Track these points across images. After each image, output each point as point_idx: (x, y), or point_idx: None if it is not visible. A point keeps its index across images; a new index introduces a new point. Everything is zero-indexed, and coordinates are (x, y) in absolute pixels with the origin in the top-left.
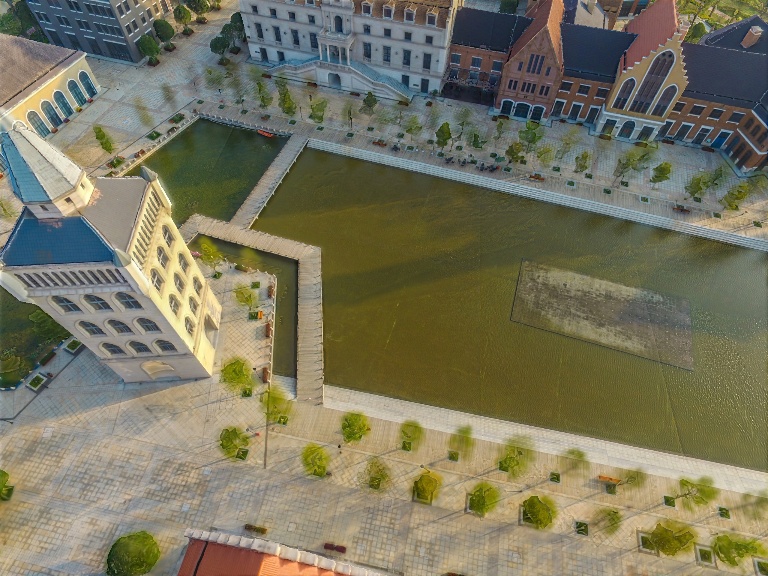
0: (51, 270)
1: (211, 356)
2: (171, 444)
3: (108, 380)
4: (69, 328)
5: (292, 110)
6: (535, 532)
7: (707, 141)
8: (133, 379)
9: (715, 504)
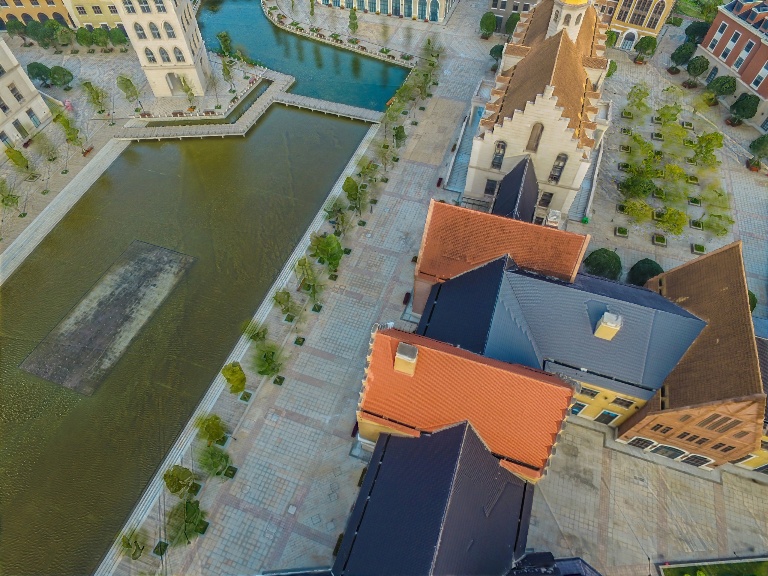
0: None
1: (165, 92)
2: None
3: None
4: None
5: (401, 100)
6: None
7: None
8: None
9: None
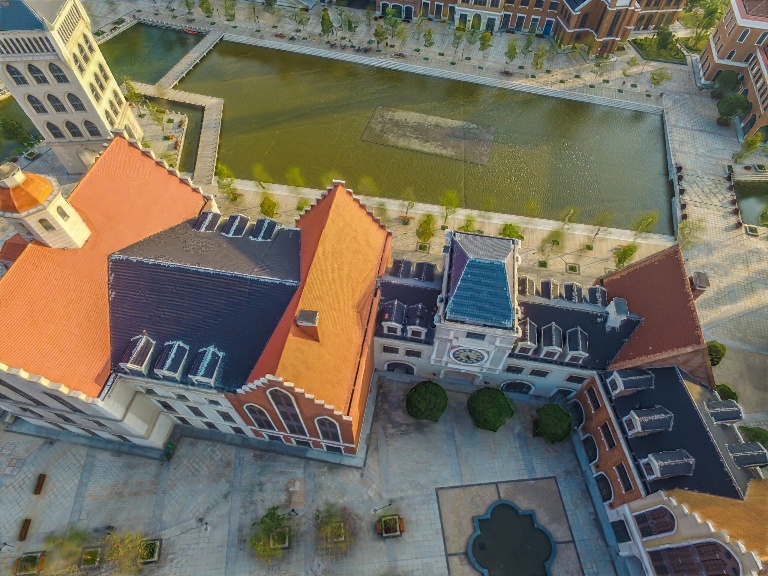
0: (3, 36)
1: None
2: None
3: (56, 173)
4: (21, 103)
5: (210, 11)
6: None
7: (539, 30)
8: (74, 170)
9: (475, 228)
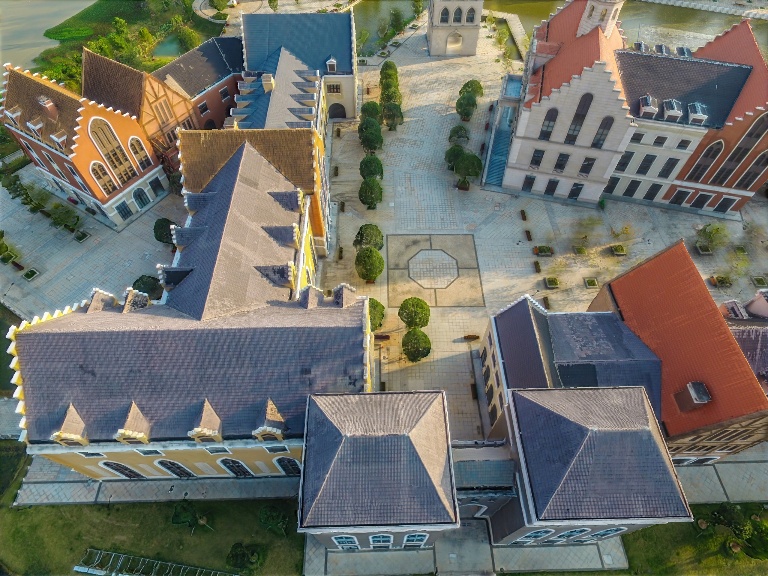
0: None
1: None
2: (465, 75)
3: (420, 55)
4: None
5: None
6: None
7: None
8: (436, 53)
9: None
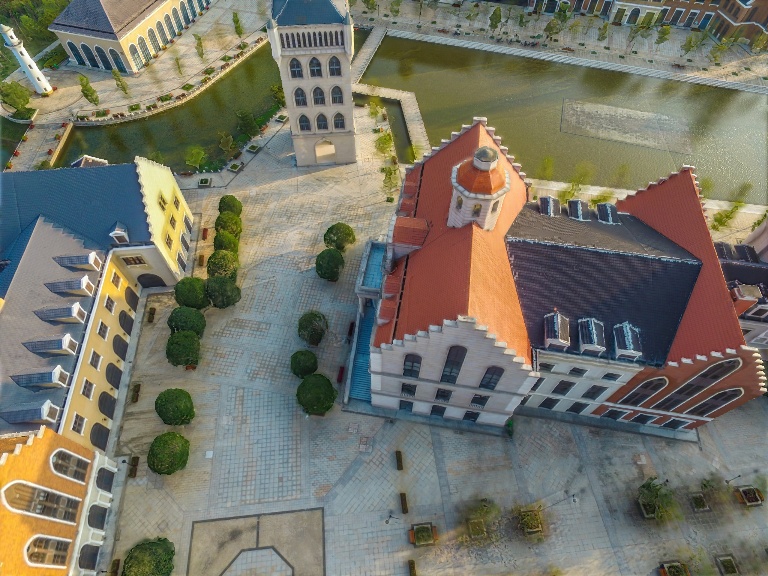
0: (304, 30)
1: None
2: (340, 196)
3: (284, 166)
4: (287, 96)
5: (374, 7)
6: None
7: (695, 24)
8: (304, 163)
9: (711, 216)
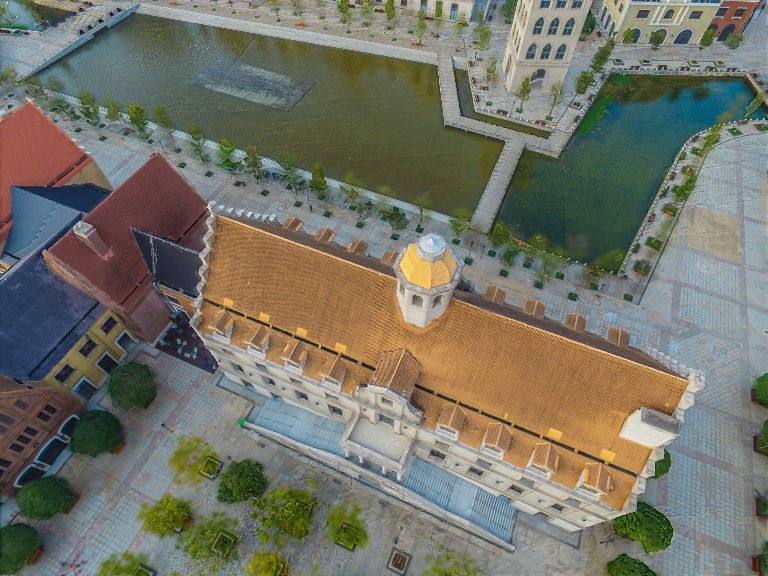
0: None
1: None
2: None
3: None
4: None
5: None
6: (343, 18)
7: None
8: None
9: None
